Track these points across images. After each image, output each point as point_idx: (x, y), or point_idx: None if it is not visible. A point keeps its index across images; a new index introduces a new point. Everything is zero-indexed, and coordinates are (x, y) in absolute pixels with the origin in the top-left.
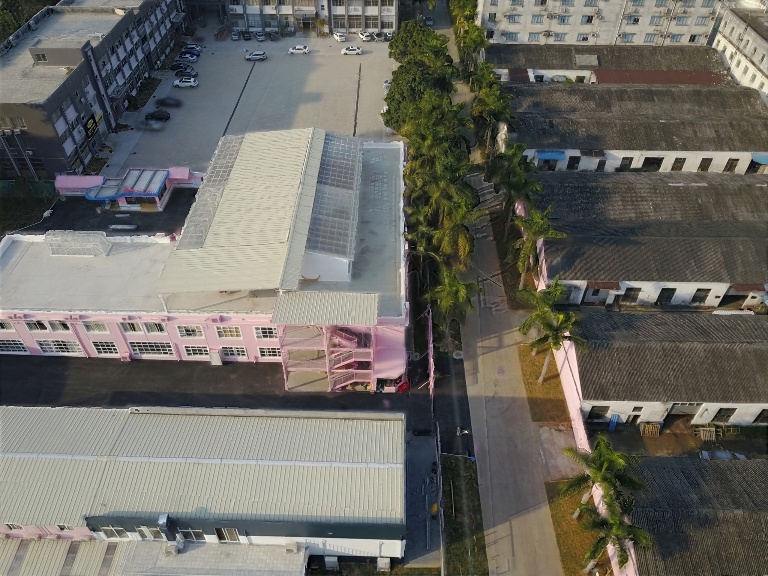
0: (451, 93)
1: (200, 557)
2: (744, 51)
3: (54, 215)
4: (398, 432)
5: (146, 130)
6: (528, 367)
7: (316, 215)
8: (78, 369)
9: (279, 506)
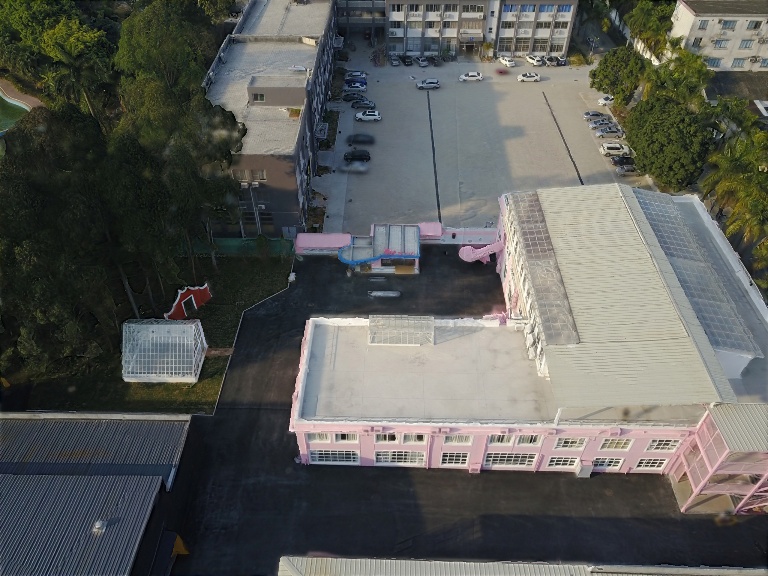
0: None
1: None
2: None
3: (299, 279)
4: None
5: (350, 172)
6: None
7: (690, 298)
8: (423, 484)
9: None
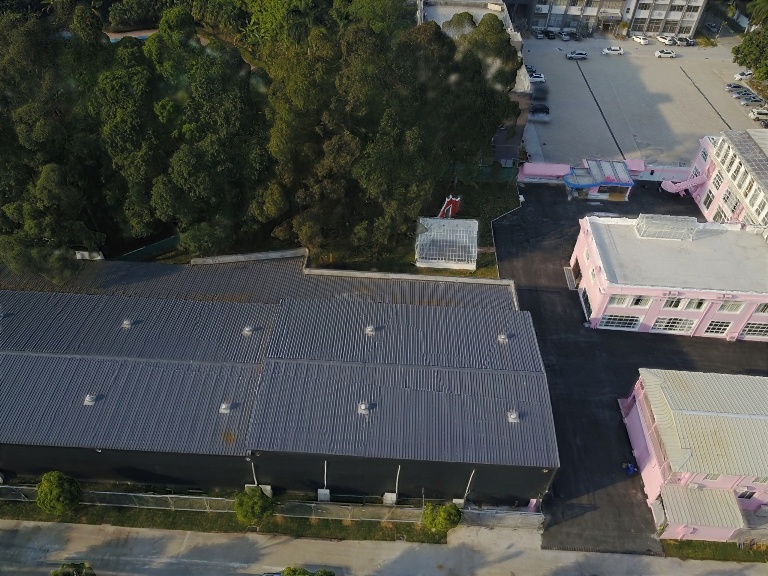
0: None
1: None
2: None
3: (528, 200)
4: None
5: (536, 122)
6: None
7: None
8: (692, 347)
9: None
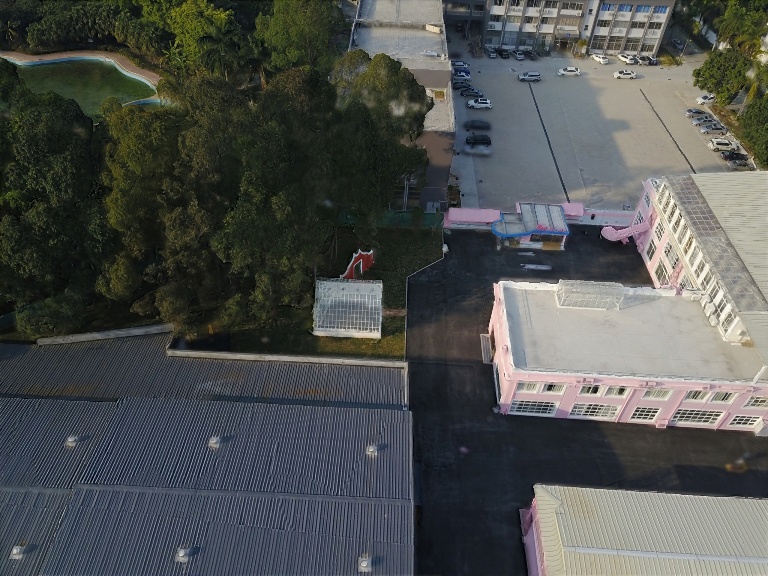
0: None
1: None
2: None
3: (452, 250)
4: None
5: (475, 155)
6: None
7: None
8: (615, 436)
9: None
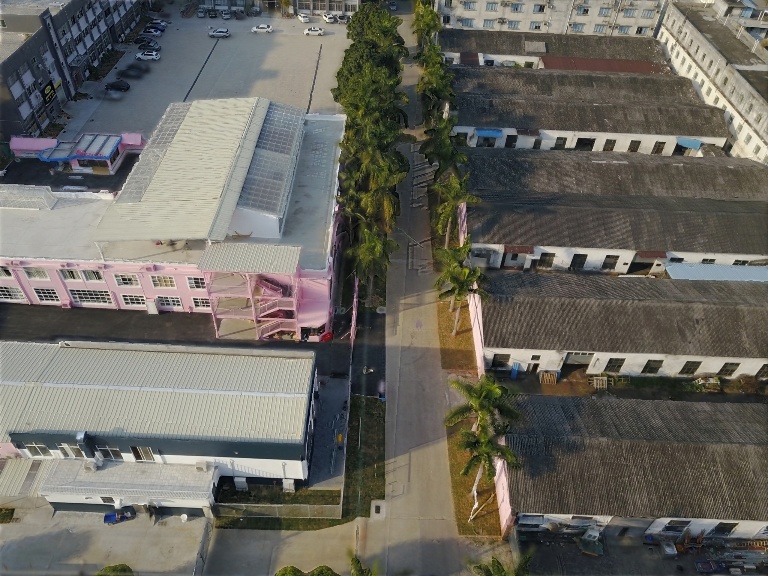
0: (405, 74)
1: (117, 474)
2: (682, 43)
3: (8, 175)
4: (308, 368)
5: (105, 99)
6: (445, 322)
7: (251, 176)
8: (20, 314)
9: (190, 428)
